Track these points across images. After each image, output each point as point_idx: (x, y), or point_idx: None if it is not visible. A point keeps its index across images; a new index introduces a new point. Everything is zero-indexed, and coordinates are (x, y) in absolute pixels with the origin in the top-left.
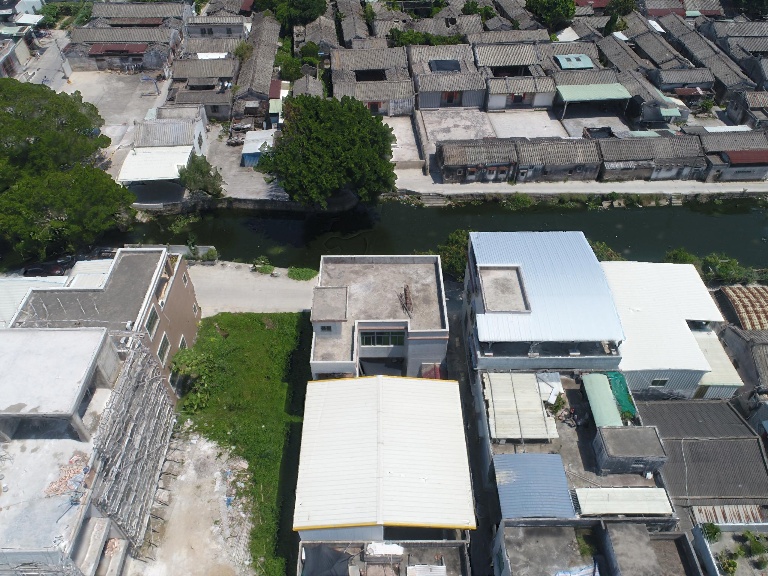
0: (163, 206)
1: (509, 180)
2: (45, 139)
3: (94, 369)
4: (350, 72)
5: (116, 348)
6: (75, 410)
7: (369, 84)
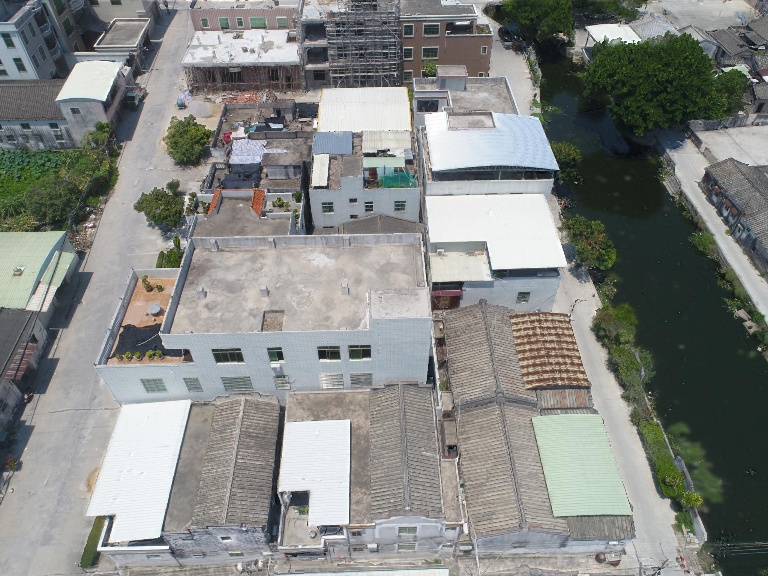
0: (588, 61)
1: (731, 228)
2: None
3: None
4: None
5: (394, 6)
6: None
7: None
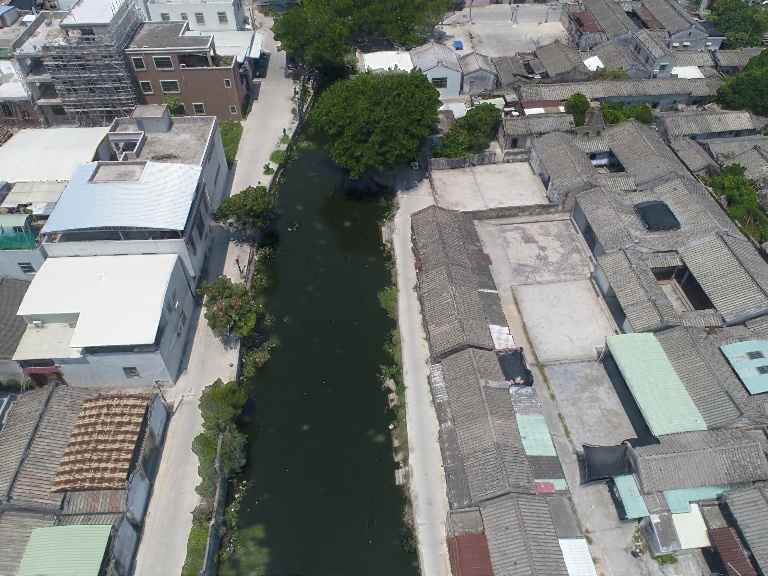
0: None
1: None
2: (371, 6)
3: (89, 28)
4: (603, 145)
5: (115, 38)
6: (63, 27)
7: (566, 154)
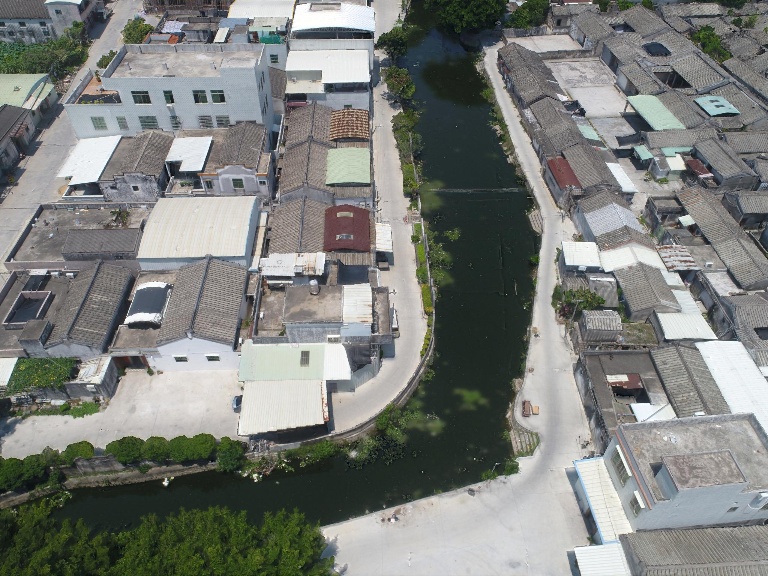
0: None
1: None
2: None
3: None
4: (620, 20)
5: None
6: None
7: (596, 22)
